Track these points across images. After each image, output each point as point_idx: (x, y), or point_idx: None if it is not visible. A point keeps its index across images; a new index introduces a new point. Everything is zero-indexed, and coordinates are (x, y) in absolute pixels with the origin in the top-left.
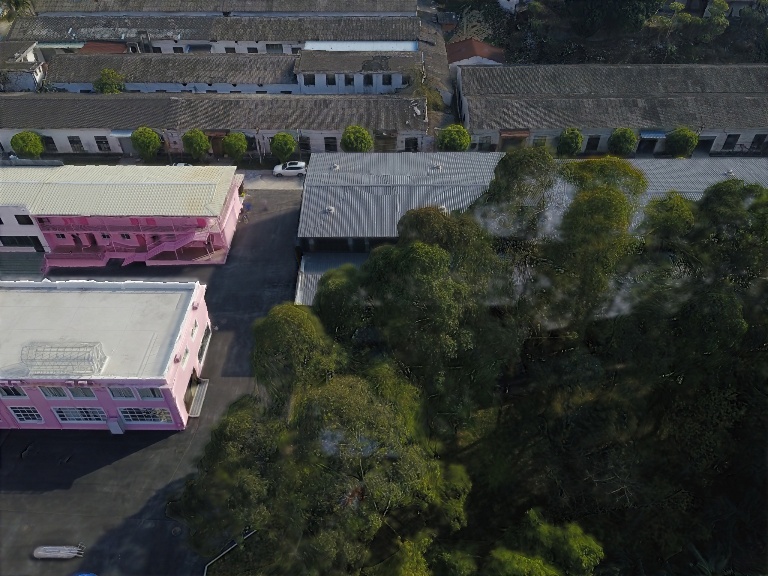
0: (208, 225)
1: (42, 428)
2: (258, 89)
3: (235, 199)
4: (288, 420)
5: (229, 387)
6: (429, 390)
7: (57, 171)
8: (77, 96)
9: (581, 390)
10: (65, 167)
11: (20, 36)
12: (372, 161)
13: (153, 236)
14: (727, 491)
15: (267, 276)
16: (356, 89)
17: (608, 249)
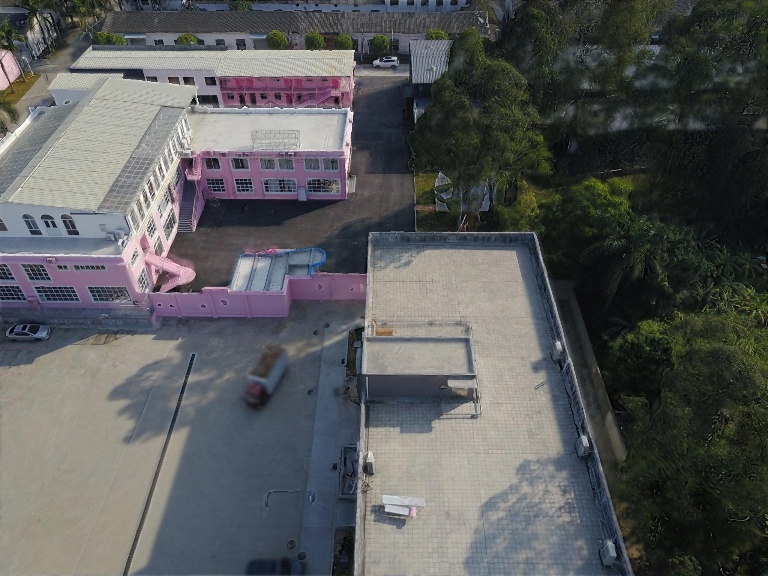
0: (341, 85)
1: (251, 198)
2: (354, 9)
3: (352, 76)
4: (474, 84)
5: (371, 179)
6: (535, 101)
7: (226, 52)
8: None
9: (619, 116)
10: (230, 51)
11: None
12: None
13: (299, 96)
14: (706, 190)
15: (383, 122)
16: (430, 9)
17: (636, 21)
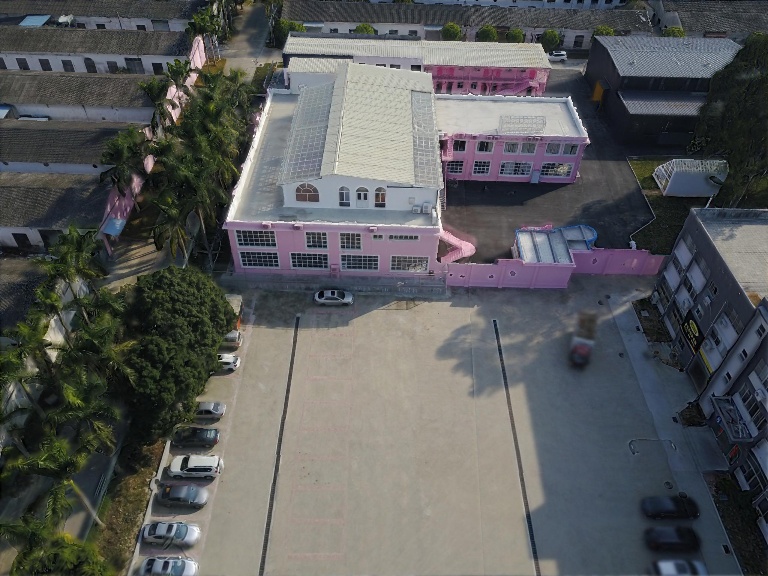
0: (539, 76)
1: (484, 180)
2: (512, 4)
3: None
4: None
5: (589, 165)
6: None
7: (421, 42)
8: None
9: None
10: (423, 41)
11: None
12: (641, 40)
13: (496, 85)
14: None
15: None
16: (584, 6)
17: None
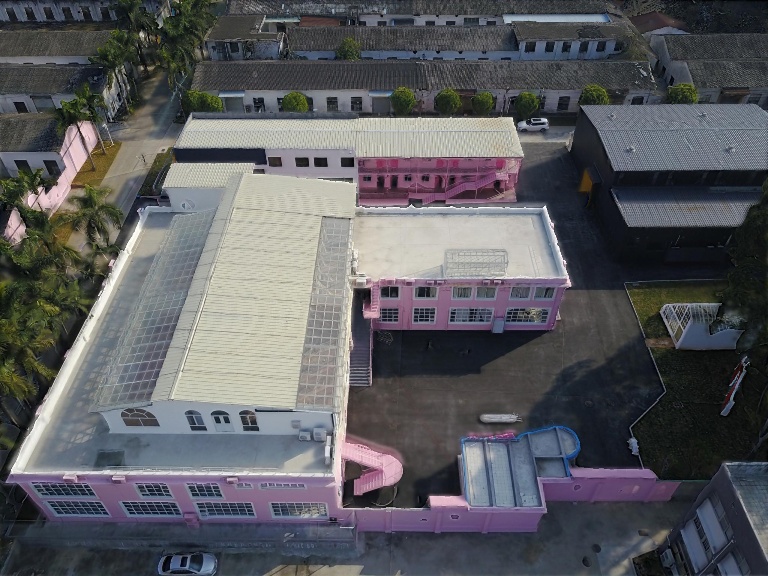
0: (509, 166)
1: (429, 329)
2: (481, 56)
3: None
4: None
5: (573, 297)
6: None
7: (358, 122)
8: (327, 62)
9: None
10: (361, 119)
11: (238, 12)
12: (641, 111)
13: (453, 178)
14: None
15: (560, 211)
16: (571, 55)
17: None
